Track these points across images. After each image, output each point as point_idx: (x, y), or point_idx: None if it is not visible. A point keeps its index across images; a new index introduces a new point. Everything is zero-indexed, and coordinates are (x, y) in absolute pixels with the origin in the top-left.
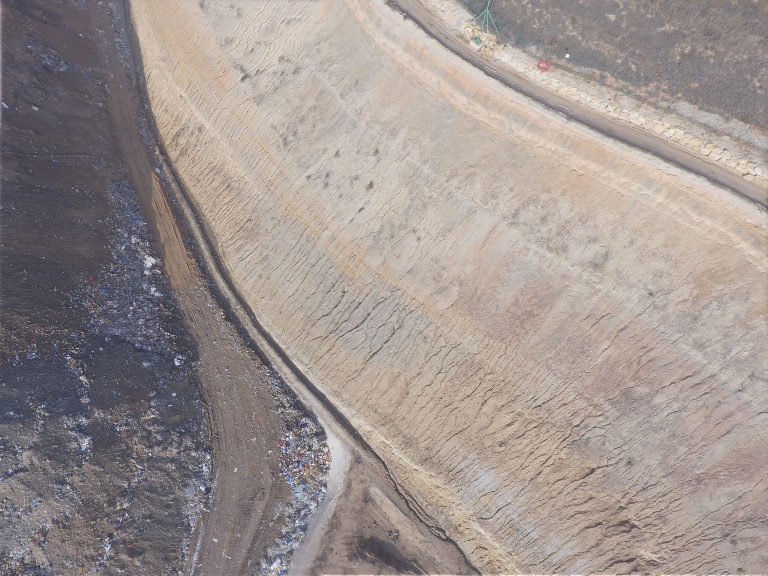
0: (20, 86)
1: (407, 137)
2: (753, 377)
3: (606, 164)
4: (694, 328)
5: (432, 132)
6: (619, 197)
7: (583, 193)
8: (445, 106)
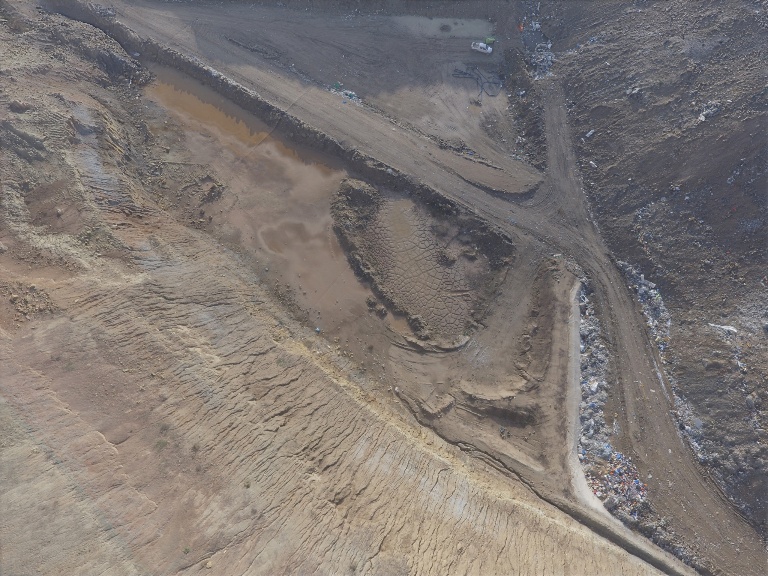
0: None
1: None
2: None
3: None
4: None
5: None
6: None
7: None
8: None
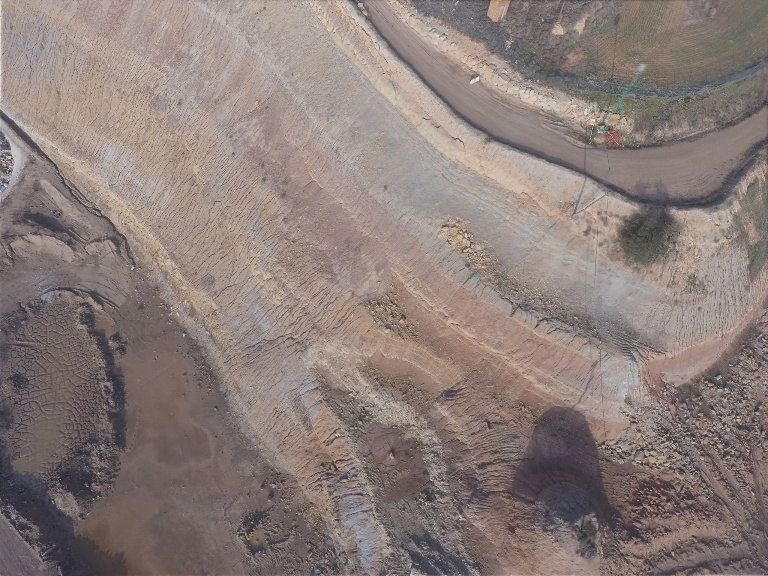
0: None
1: None
2: (231, 12)
3: None
4: None
5: None
6: None
7: None
8: None
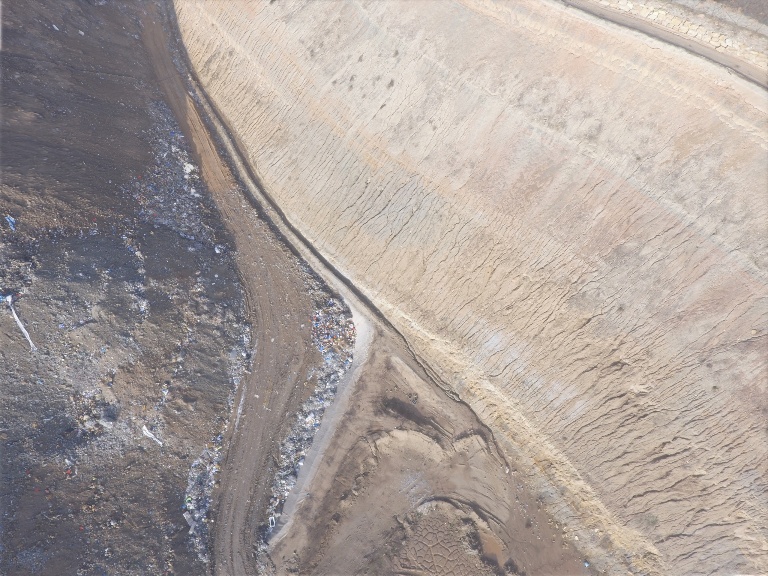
0: (67, 13)
1: (424, 38)
2: (725, 221)
3: (599, 44)
4: (675, 184)
5: (446, 31)
6: (610, 75)
7: (579, 74)
8: (458, 6)
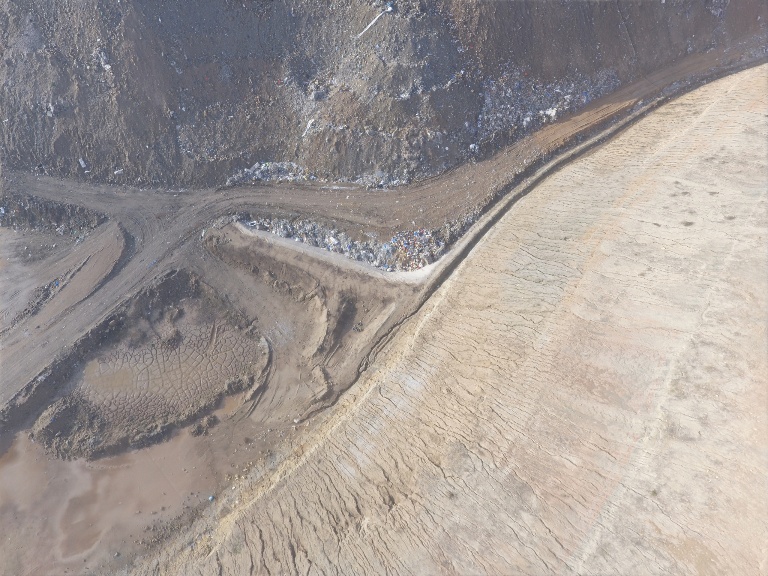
0: None
1: (762, 235)
2: None
3: None
4: (625, 542)
5: None
6: None
7: (765, 401)
8: None
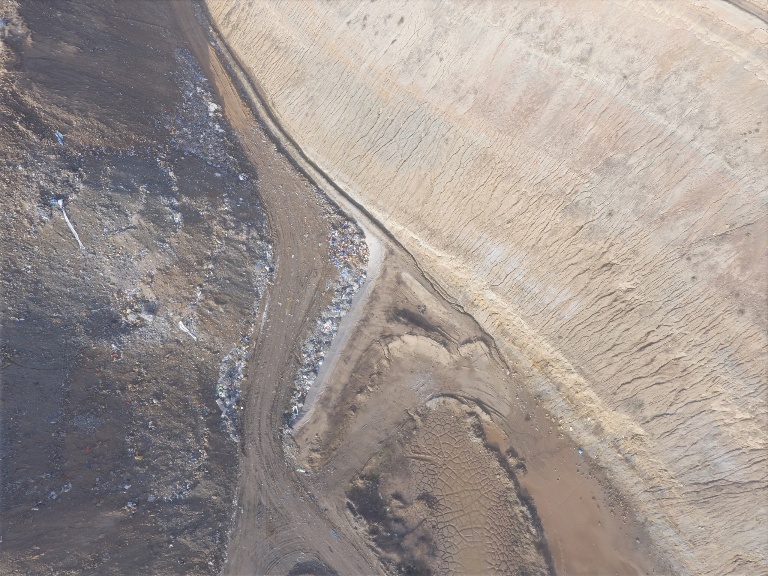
0: None
1: None
2: (702, 128)
3: None
4: (658, 98)
5: None
6: (600, 2)
7: (572, 2)
8: None
